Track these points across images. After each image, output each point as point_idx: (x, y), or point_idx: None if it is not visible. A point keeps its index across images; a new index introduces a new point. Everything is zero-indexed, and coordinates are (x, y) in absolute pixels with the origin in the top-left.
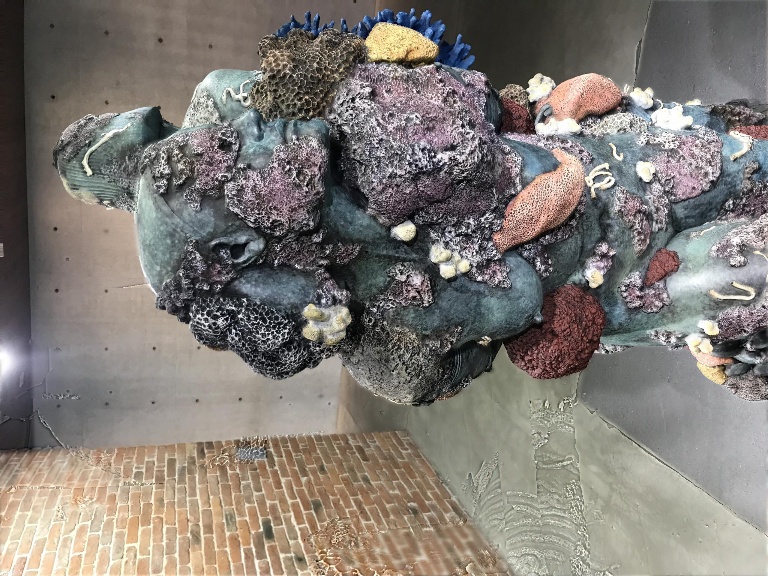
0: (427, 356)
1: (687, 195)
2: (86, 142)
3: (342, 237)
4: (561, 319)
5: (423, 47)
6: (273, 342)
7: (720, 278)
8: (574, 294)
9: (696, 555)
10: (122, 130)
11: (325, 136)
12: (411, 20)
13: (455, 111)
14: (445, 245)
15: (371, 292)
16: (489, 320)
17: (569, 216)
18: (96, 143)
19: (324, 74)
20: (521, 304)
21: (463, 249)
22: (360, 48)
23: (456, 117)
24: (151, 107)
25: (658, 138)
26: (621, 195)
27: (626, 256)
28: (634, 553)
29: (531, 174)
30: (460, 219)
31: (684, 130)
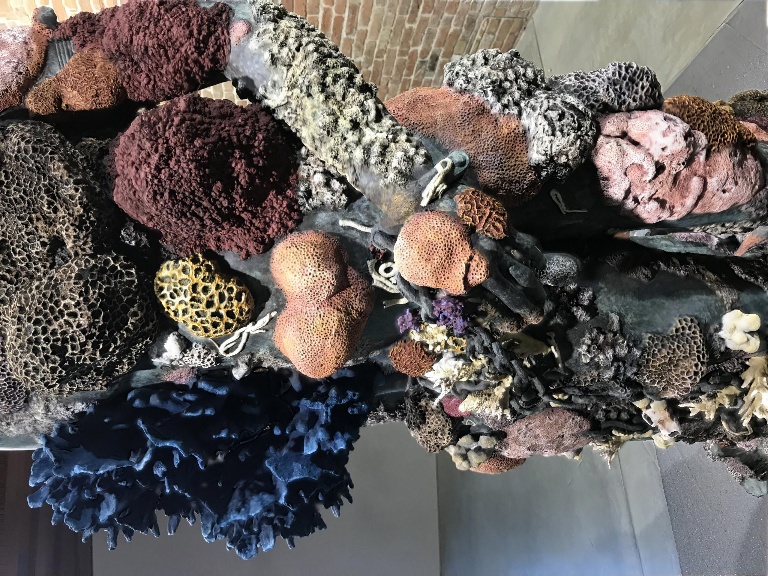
0: None
1: None
2: None
3: None
4: None
5: None
6: None
7: None
8: None
9: None
10: None
11: None
12: None
13: None
14: None
15: None
16: None
17: None
18: None
19: None
20: None
21: None
22: None
23: None
24: None
25: None
26: None
27: None
28: None
29: None
30: None
31: None
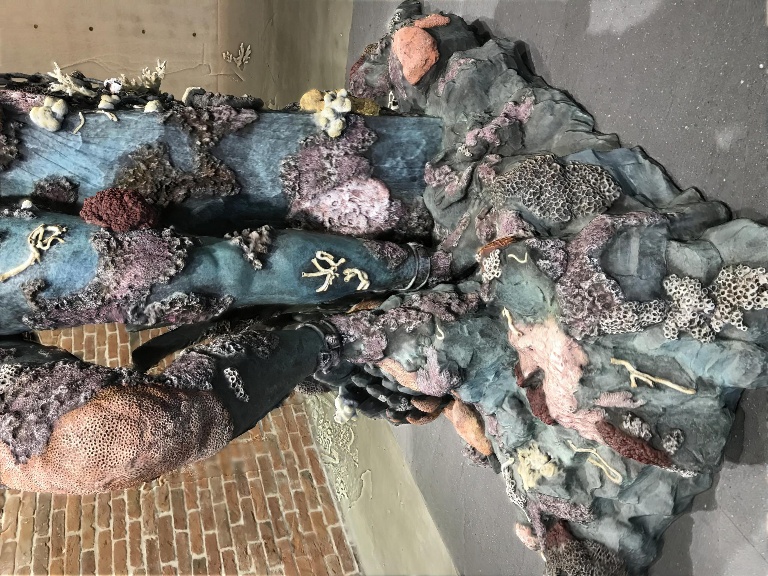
0: None
1: None
2: None
3: None
4: None
5: None
6: None
7: None
8: None
9: (393, 437)
10: None
11: None
12: None
13: None
14: None
15: None
16: None
17: None
18: None
19: None
20: None
21: None
22: None
23: None
24: None
25: None
26: None
27: None
28: (363, 420)
29: None
30: None
31: None
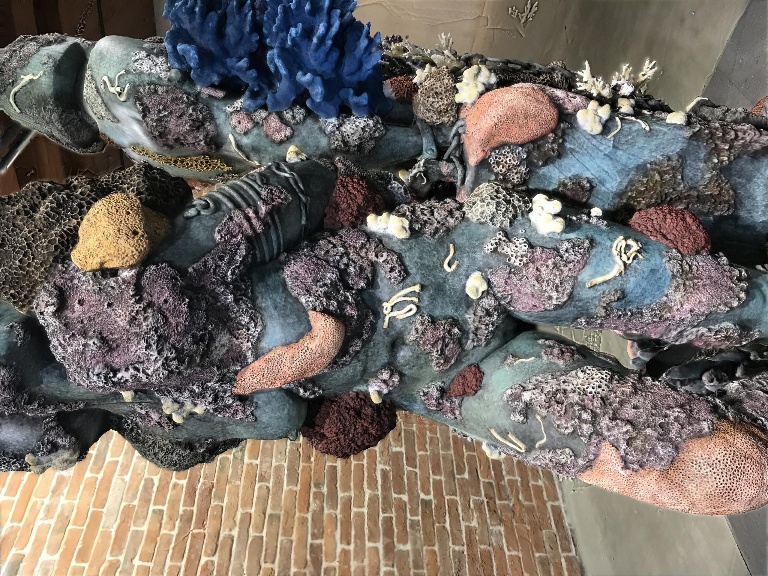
0: (181, 454)
1: (527, 310)
2: (10, 81)
3: (63, 399)
4: (330, 427)
5: (118, 259)
6: (8, 469)
7: (502, 423)
8: (353, 405)
9: None
10: (36, 78)
11: (6, 356)
12: (305, 8)
13: (141, 332)
14: (175, 399)
15: (122, 412)
16: (240, 436)
17: (343, 352)
18: (17, 85)
19: (28, 270)
20: (269, 431)
21: (196, 400)
22: (74, 233)
23: (141, 338)
24: (68, 46)
25: (507, 248)
26: (419, 326)
27: (423, 373)
28: None
29: (269, 345)
30: (183, 386)
31: (553, 234)
